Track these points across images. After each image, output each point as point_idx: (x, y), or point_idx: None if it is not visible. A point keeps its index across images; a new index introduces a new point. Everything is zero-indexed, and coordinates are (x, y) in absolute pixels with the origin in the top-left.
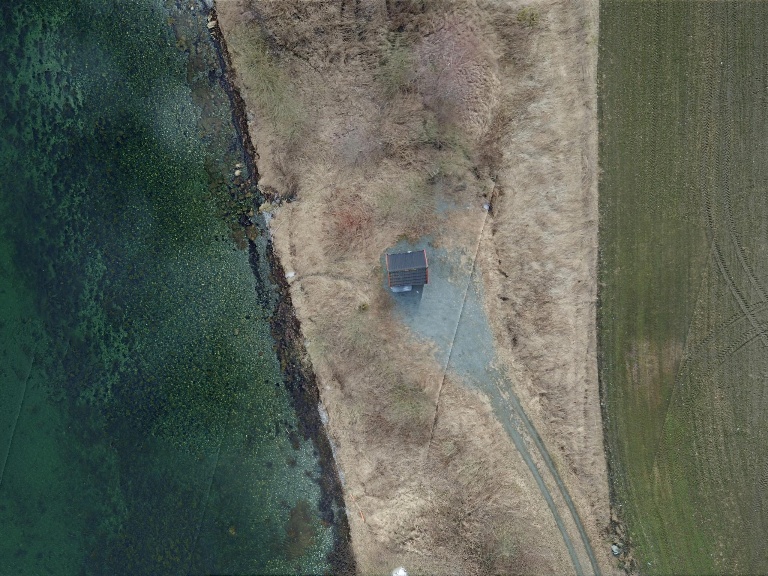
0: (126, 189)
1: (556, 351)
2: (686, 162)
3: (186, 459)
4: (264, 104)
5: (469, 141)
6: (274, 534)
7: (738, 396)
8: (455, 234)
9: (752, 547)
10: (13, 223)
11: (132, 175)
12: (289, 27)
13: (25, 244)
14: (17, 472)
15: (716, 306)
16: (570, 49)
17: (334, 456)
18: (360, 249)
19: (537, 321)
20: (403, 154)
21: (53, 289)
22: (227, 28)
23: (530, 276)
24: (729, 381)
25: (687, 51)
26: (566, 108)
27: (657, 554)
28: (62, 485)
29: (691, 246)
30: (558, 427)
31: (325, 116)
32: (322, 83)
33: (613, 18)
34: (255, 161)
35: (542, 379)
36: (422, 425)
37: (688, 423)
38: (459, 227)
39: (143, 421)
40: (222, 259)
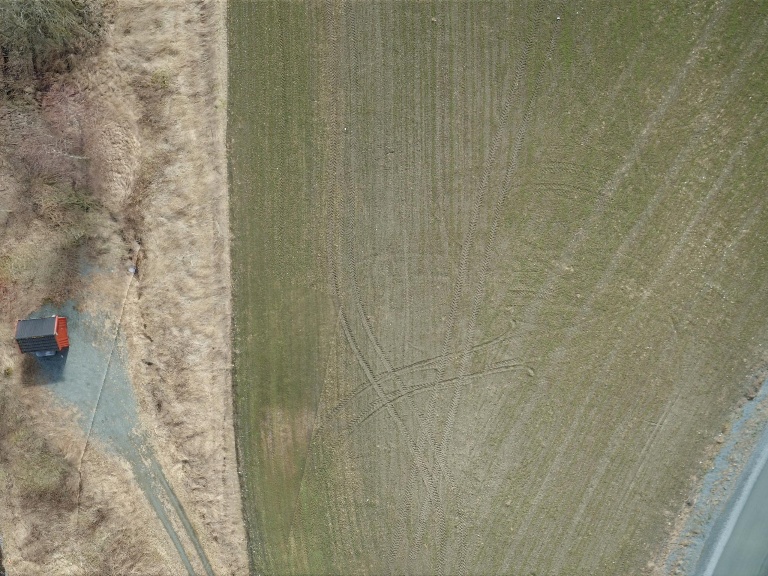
0: None
1: (194, 418)
2: (313, 229)
3: None
4: None
5: (114, 203)
6: None
7: (367, 466)
8: (99, 298)
9: None
10: None
11: None
12: None
13: None
14: None
15: (344, 375)
16: (199, 113)
17: None
18: (5, 312)
19: (177, 387)
20: (51, 215)
21: None
22: None
23: (170, 342)
24: (358, 451)
25: (312, 116)
26: (196, 173)
27: None
28: None
29: (319, 314)
30: (200, 495)
31: None
32: None
33: (240, 82)
34: None
35: (184, 446)
36: (69, 491)
37: (321, 493)
38: (103, 291)
39: None
40: None
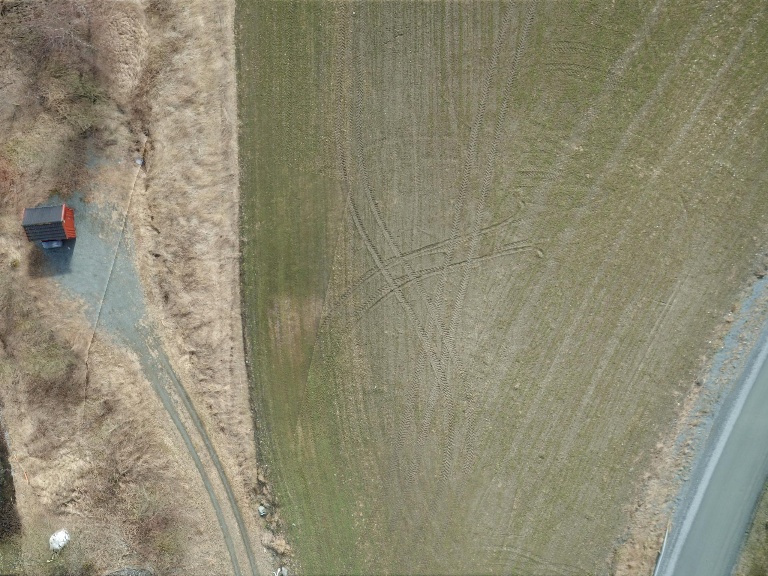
0: None
1: (202, 308)
2: (322, 114)
3: None
4: None
5: (121, 94)
6: None
7: (375, 353)
8: (106, 189)
9: (390, 507)
10: None
11: None
12: None
13: None
14: None
15: (352, 261)
16: None
17: None
18: (12, 204)
19: (184, 277)
20: (58, 108)
21: None
22: None
23: (177, 232)
24: (366, 338)
25: (321, 1)
26: (204, 59)
27: (301, 514)
28: None
29: (327, 200)
30: (207, 386)
31: None
32: None
33: None
34: None
35: (191, 337)
36: (75, 384)
37: (329, 381)
38: (110, 182)
39: None
40: None
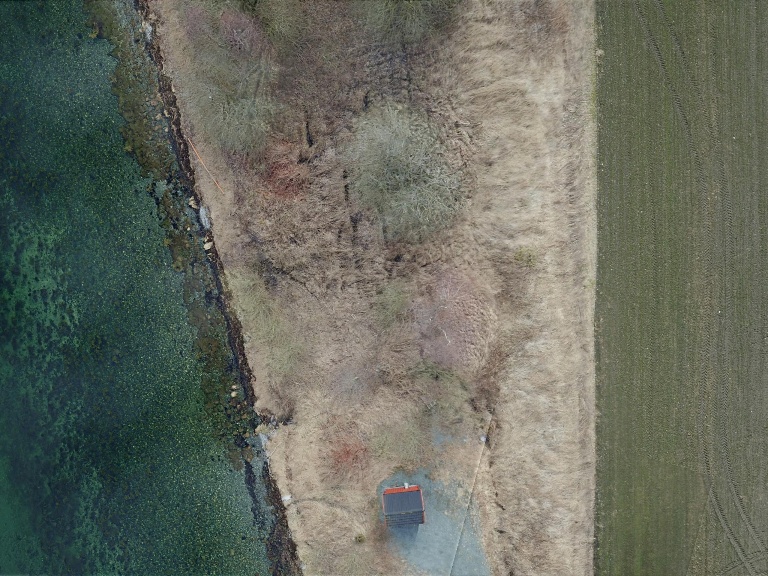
0: (122, 407)
1: None
2: (684, 408)
3: None
4: (260, 327)
5: (466, 373)
6: None
7: None
8: (452, 467)
9: None
10: (8, 439)
11: (128, 393)
12: (286, 252)
13: (20, 462)
14: None
15: (714, 552)
16: (567, 292)
17: None
18: (356, 480)
19: (534, 558)
20: (400, 383)
21: (48, 507)
22: (224, 250)
23: (527, 513)
24: None
25: (685, 298)
26: (563, 350)
27: None
28: None
29: (689, 492)
30: None
31: (322, 342)
32: (319, 308)
33: (611, 263)
34: (251, 383)
35: None
36: None
37: None
38: (456, 460)
39: None
40: (218, 479)
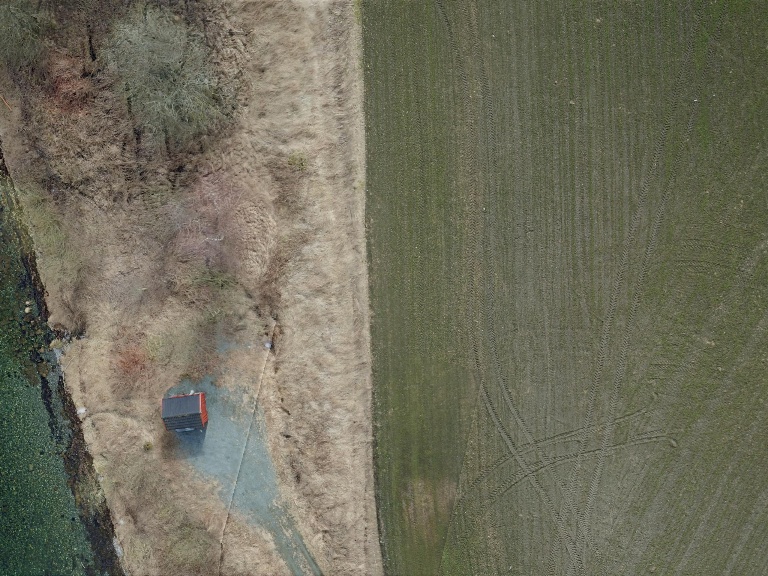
0: None
1: (335, 490)
2: (453, 305)
3: None
4: (51, 242)
5: (249, 280)
6: None
7: (510, 535)
8: (237, 373)
9: None
10: None
11: None
12: (73, 166)
13: None
14: None
15: (486, 447)
16: (338, 194)
17: None
18: (144, 389)
19: (317, 460)
20: (186, 293)
21: None
22: (13, 167)
23: (309, 415)
24: (501, 520)
25: (451, 196)
26: (336, 252)
27: None
28: None
29: (460, 388)
30: (341, 564)
31: (110, 255)
32: (107, 221)
33: (379, 163)
34: (44, 298)
35: (324, 516)
36: (209, 562)
37: (464, 561)
38: (241, 366)
39: None
40: (15, 395)
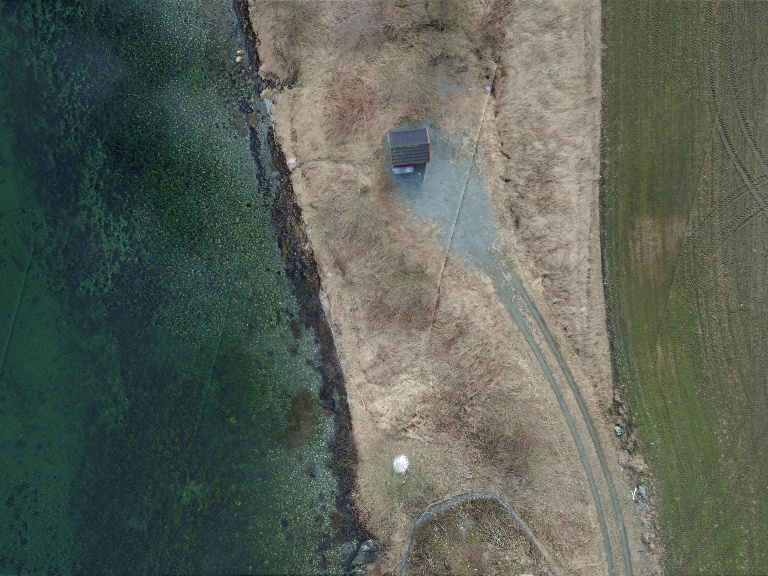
0: (126, 77)
1: (559, 231)
2: (690, 36)
3: (187, 349)
4: None
5: (471, 22)
6: (275, 423)
7: (742, 272)
8: (457, 115)
9: (756, 424)
10: (13, 112)
11: (132, 63)
12: None
13: (25, 133)
14: (17, 362)
15: (720, 181)
16: None
17: (335, 344)
18: (362, 131)
19: (540, 201)
20: (405, 37)
21: (53, 178)
22: None
23: (533, 156)
24: (733, 257)
25: None
26: None
27: (660, 433)
28: (62, 376)
29: (695, 121)
30: (561, 308)
31: None
32: None
33: None
34: (256, 47)
35: (545, 260)
36: (424, 308)
37: (691, 301)
38: (461, 108)
39: (143, 310)
40: (223, 147)
